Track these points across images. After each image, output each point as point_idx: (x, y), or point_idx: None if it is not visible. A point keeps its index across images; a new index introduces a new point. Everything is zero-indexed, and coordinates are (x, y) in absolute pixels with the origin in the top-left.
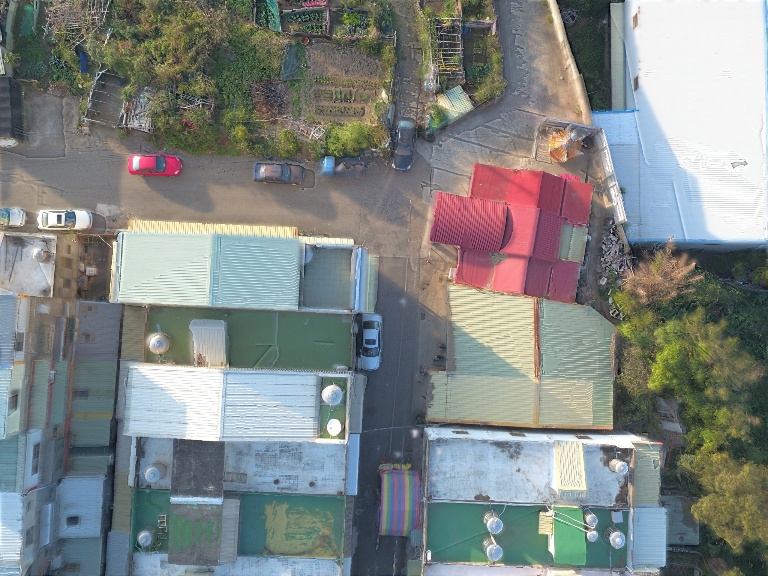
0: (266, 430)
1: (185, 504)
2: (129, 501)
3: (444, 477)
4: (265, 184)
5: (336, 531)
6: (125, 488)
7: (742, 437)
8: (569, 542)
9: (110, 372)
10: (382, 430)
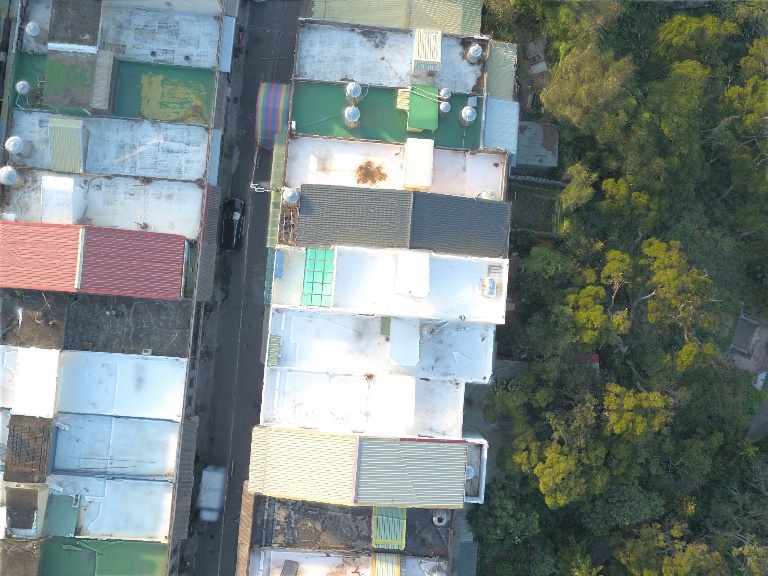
0: None
1: (61, 51)
2: None
3: (313, 61)
4: None
5: (208, 103)
6: None
7: (589, 32)
8: (423, 109)
9: None
10: (267, 59)
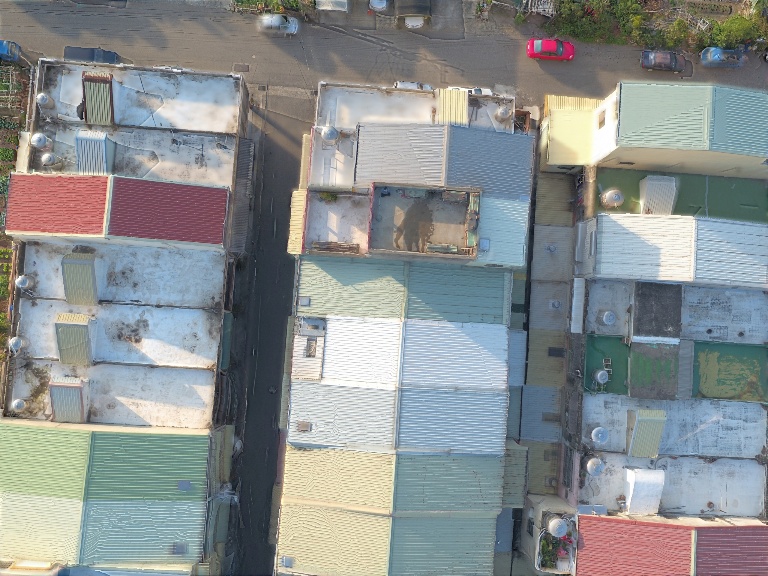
0: (728, 274)
1: (646, 343)
2: (544, 356)
3: None
4: (648, 72)
5: (762, 378)
6: (539, 344)
7: None
8: None
9: (526, 235)
10: None
